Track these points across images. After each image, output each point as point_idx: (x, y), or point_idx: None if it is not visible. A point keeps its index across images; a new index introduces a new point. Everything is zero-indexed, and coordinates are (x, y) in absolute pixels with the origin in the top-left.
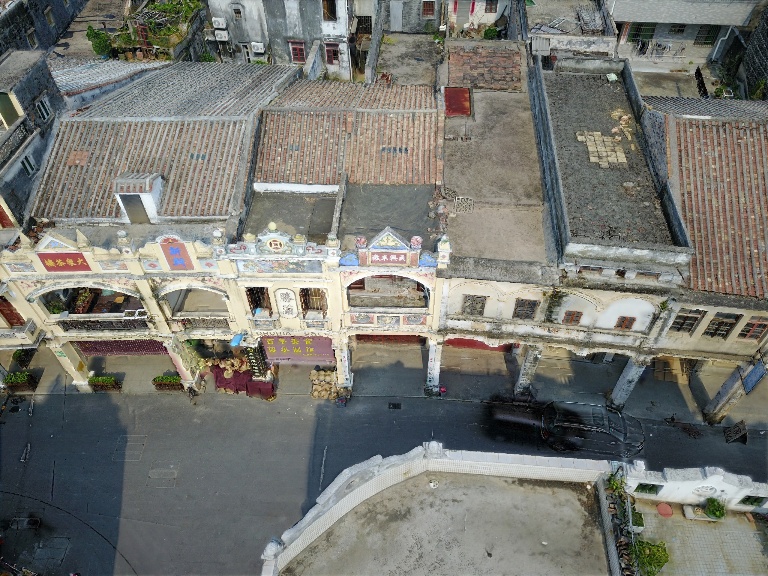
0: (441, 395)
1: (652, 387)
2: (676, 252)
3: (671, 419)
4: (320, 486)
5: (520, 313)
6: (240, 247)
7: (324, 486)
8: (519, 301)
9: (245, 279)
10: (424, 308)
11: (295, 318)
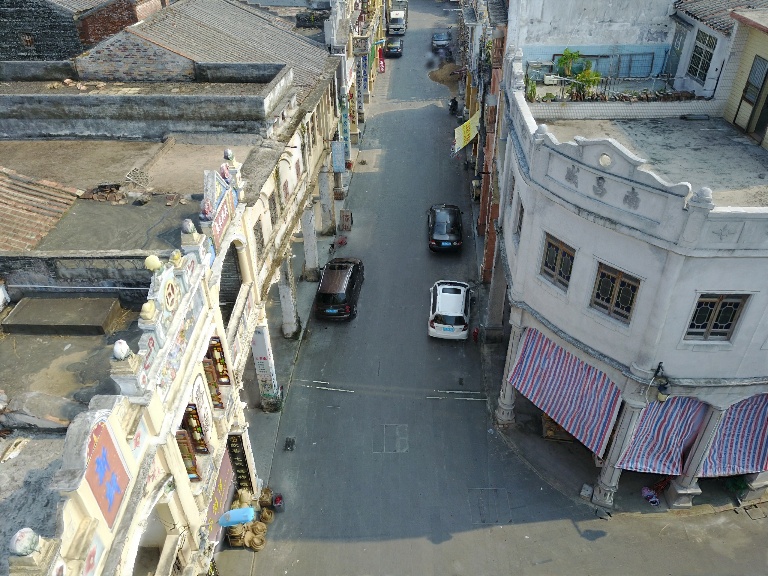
0: (282, 395)
1: None
2: (289, 69)
3: (332, 246)
4: (482, 399)
5: (272, 218)
6: (148, 347)
7: (406, 518)
8: (269, 202)
9: (176, 407)
10: (241, 287)
11: (212, 429)
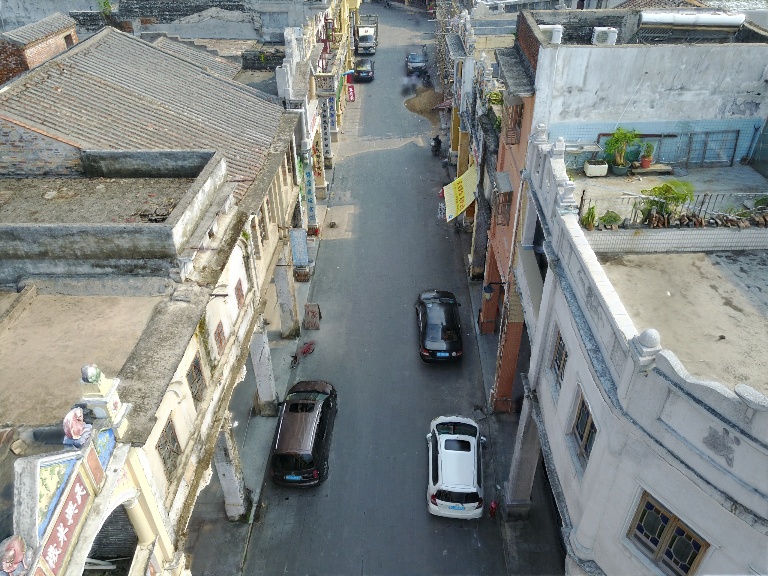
0: None
1: (247, 372)
2: (219, 161)
3: (294, 359)
4: None
5: (196, 395)
6: None
7: None
8: (188, 377)
9: None
10: (135, 553)
11: None
